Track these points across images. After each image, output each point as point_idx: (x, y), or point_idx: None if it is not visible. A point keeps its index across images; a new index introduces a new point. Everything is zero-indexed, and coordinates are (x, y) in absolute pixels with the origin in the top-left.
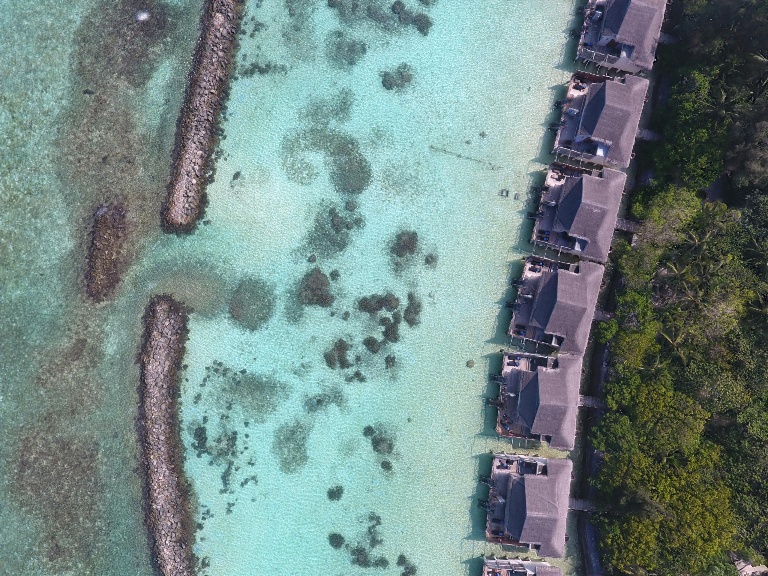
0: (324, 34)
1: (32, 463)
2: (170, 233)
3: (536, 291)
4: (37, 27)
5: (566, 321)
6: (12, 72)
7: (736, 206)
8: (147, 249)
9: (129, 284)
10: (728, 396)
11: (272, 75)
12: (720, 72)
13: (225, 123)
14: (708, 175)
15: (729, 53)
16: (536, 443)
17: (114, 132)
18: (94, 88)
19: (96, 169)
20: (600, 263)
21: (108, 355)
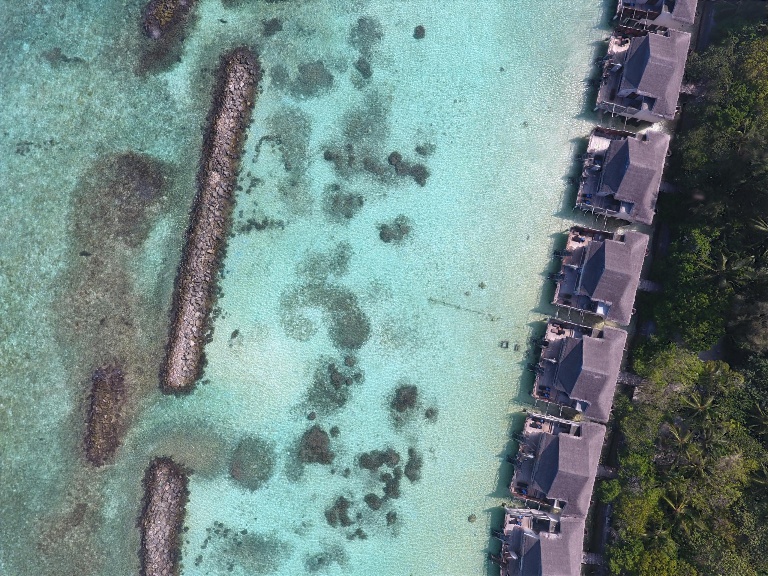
0: (321, 188)
1: None
2: (169, 394)
3: (537, 453)
4: (33, 189)
5: (568, 488)
6: (9, 235)
7: (738, 366)
8: (146, 411)
9: (129, 447)
10: (732, 573)
11: (269, 231)
12: (721, 233)
13: (222, 281)
14: (710, 339)
15: (730, 217)
16: None
17: (111, 294)
18: (91, 249)
19: (94, 331)
20: (602, 423)
21: (109, 519)
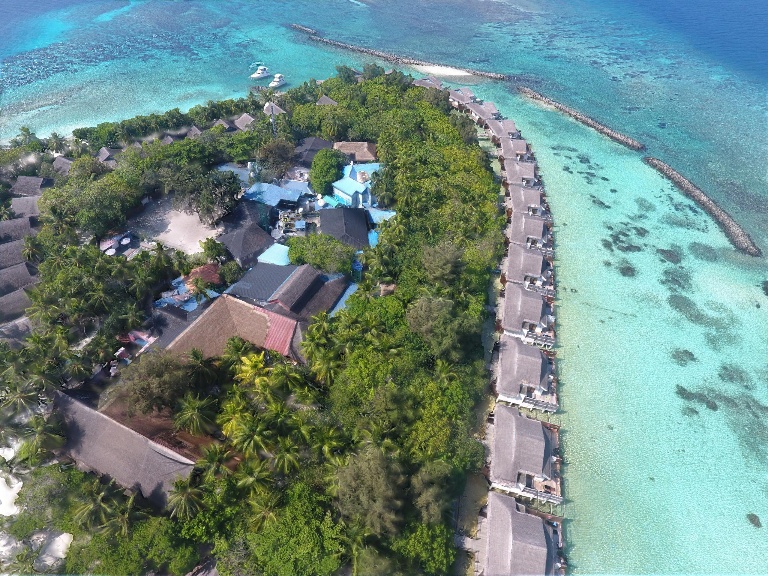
0: (760, 388)
1: None
2: None
3: None
4: None
5: None
6: None
7: None
8: None
9: None
10: None
11: None
12: None
13: None
14: None
15: None
16: None
17: None
18: None
19: None
20: None
21: (766, 238)
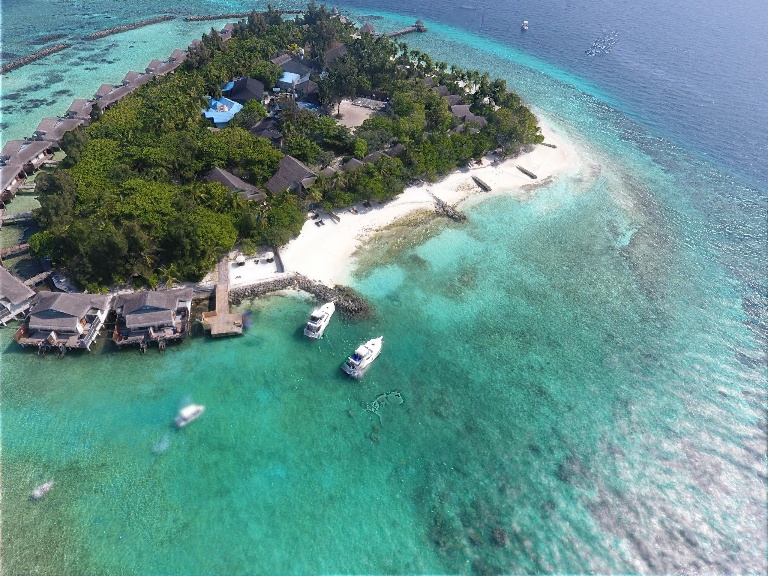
0: None
1: None
2: None
3: None
4: None
5: (105, 90)
6: None
7: None
8: None
9: None
10: None
11: (43, 65)
12: None
13: (14, 70)
14: (183, 70)
15: None
16: None
17: None
18: None
19: None
20: None
21: None
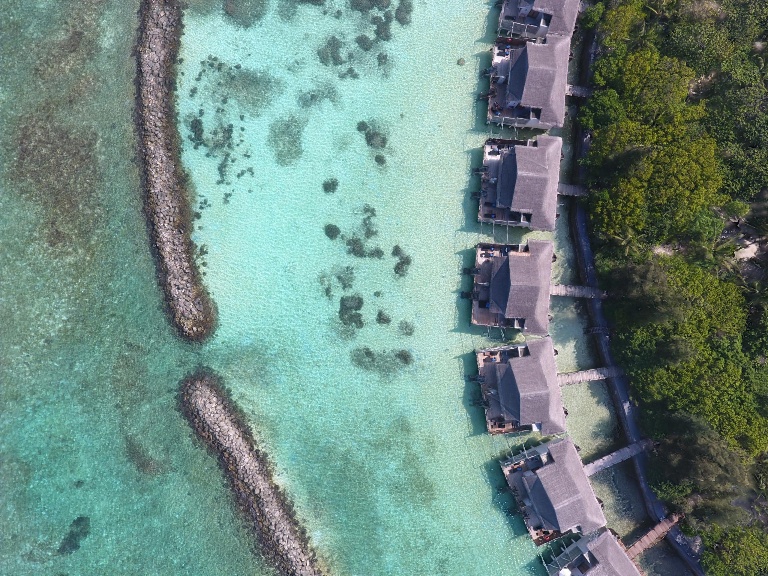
0: None
1: (31, 151)
2: None
3: None
4: None
5: None
6: None
7: None
8: None
9: None
10: (712, 45)
11: None
12: None
13: None
14: None
15: None
16: (527, 139)
17: None
18: None
19: None
20: None
21: (105, 48)
